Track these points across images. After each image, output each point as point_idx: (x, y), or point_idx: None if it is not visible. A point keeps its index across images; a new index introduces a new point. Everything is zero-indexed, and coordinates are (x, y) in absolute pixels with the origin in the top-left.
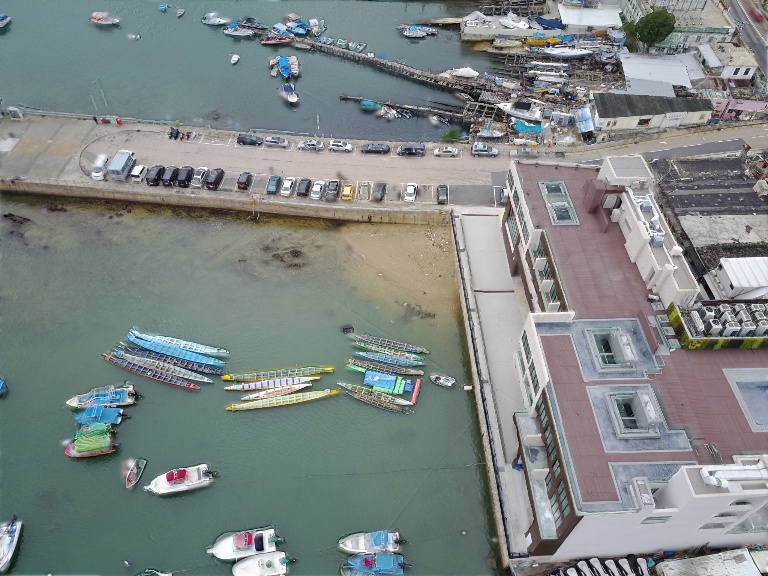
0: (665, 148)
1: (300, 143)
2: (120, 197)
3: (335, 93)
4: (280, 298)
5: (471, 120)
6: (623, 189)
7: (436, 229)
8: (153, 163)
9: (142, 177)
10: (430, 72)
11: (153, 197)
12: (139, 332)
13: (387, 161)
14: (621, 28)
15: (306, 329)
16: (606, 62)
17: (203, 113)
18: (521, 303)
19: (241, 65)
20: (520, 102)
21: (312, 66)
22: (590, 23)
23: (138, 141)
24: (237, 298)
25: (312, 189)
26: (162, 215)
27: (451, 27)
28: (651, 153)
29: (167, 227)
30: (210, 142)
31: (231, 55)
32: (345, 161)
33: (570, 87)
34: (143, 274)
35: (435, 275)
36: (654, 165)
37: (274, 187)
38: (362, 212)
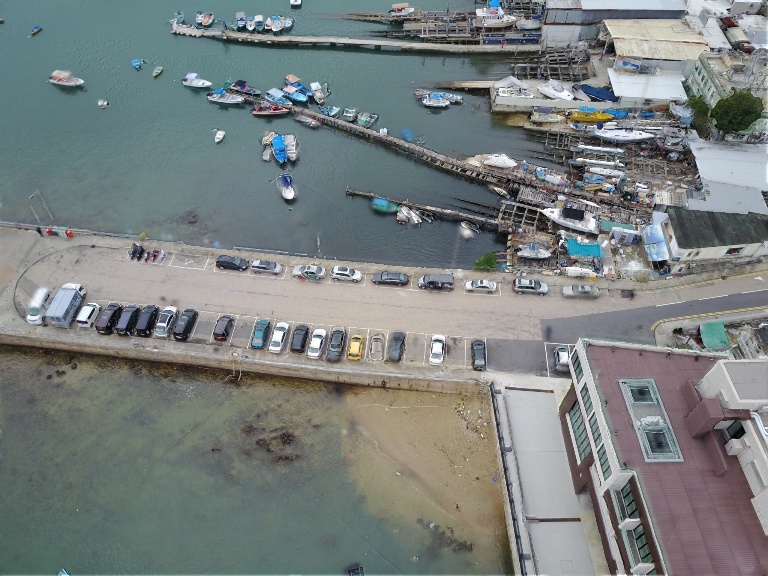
0: (762, 287)
1: (296, 269)
2: (63, 347)
3: (340, 186)
4: (265, 513)
5: (509, 230)
6: (747, 415)
7: (470, 401)
8: (108, 298)
9: (91, 321)
10: (456, 159)
11: (105, 349)
12: (72, 571)
13: (406, 297)
14: (687, 104)
15: (298, 568)
16: (671, 149)
17: (177, 214)
18: (591, 541)
19: (227, 142)
20: (570, 209)
21: (313, 144)
22: (648, 95)
23: (91, 263)
24: (207, 512)
25: (310, 344)
26: (116, 373)
27: (479, 92)
28: (745, 295)
29: (121, 392)
30: (182, 264)
31: (215, 132)
32: (352, 296)
33: (628, 181)
34: (85, 471)
35: (470, 477)
36: (762, 332)
37: (260, 340)
38: (374, 377)
